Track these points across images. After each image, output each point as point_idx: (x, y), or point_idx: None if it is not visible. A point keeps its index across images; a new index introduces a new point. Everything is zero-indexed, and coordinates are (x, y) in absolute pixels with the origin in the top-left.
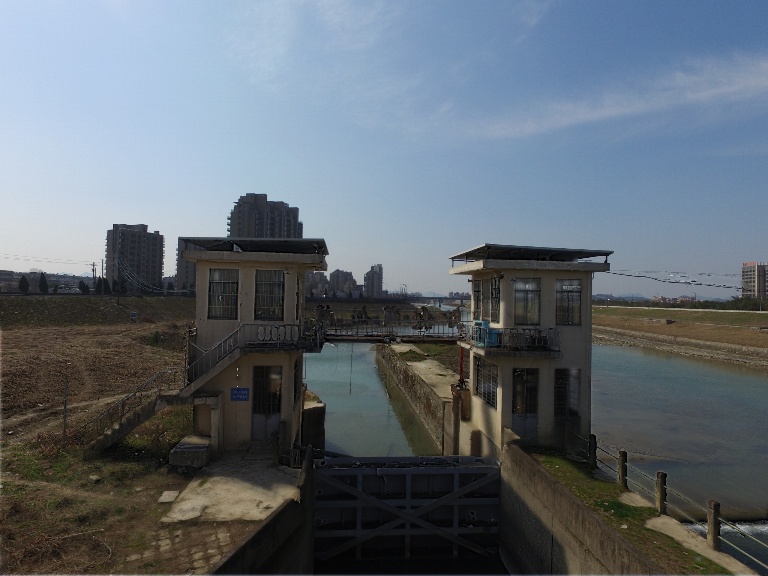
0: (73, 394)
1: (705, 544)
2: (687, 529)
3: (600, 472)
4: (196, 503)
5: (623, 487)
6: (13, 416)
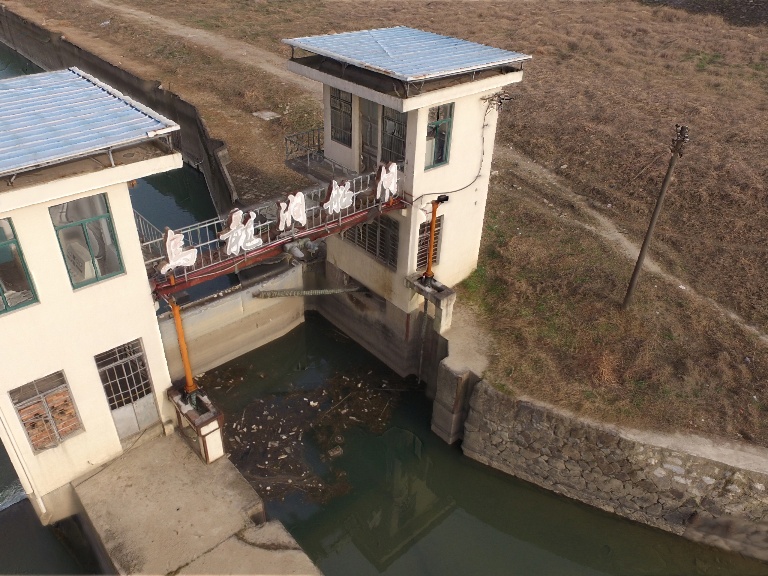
0: (657, 225)
1: None
2: None
3: None
4: None
5: None
6: (579, 195)
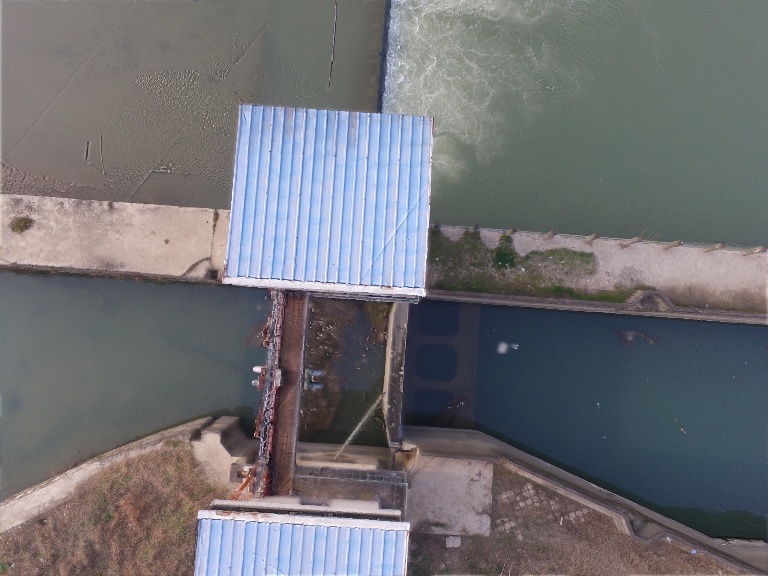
0: None
1: (542, 239)
2: (527, 235)
3: (446, 231)
4: (472, 521)
5: (475, 234)
6: None
